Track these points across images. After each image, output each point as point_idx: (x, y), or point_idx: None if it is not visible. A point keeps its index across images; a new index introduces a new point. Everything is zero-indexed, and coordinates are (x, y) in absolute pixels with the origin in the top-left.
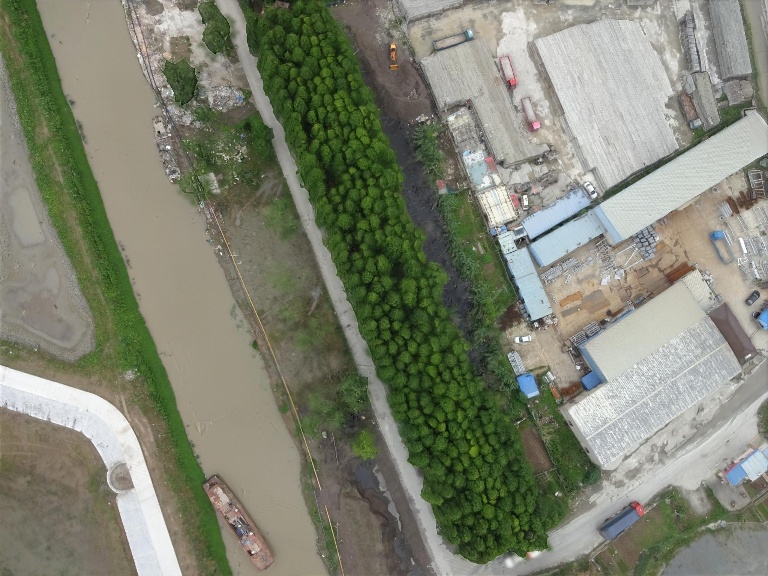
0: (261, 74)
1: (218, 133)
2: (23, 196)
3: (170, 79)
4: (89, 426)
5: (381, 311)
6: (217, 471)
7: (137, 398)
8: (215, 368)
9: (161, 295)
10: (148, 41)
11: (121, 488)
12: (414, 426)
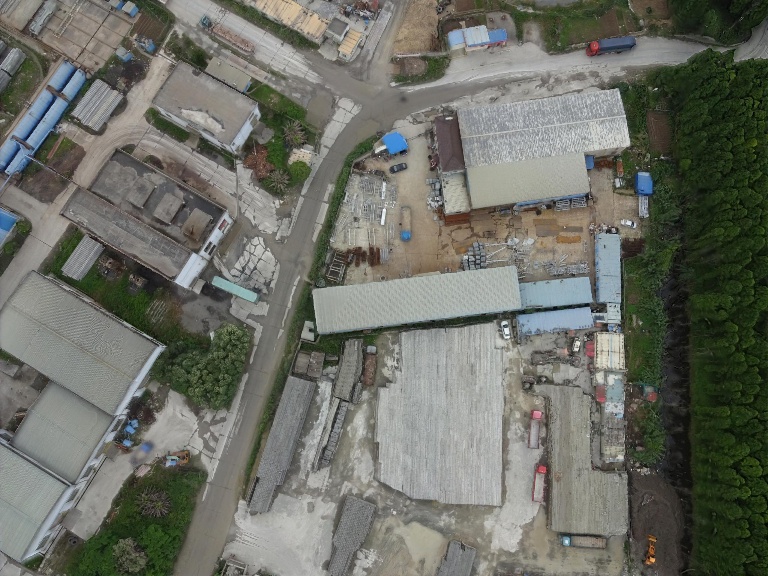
0: None
1: None
2: None
3: None
4: None
5: None
6: None
7: None
8: None
9: None
10: None
11: None
12: None
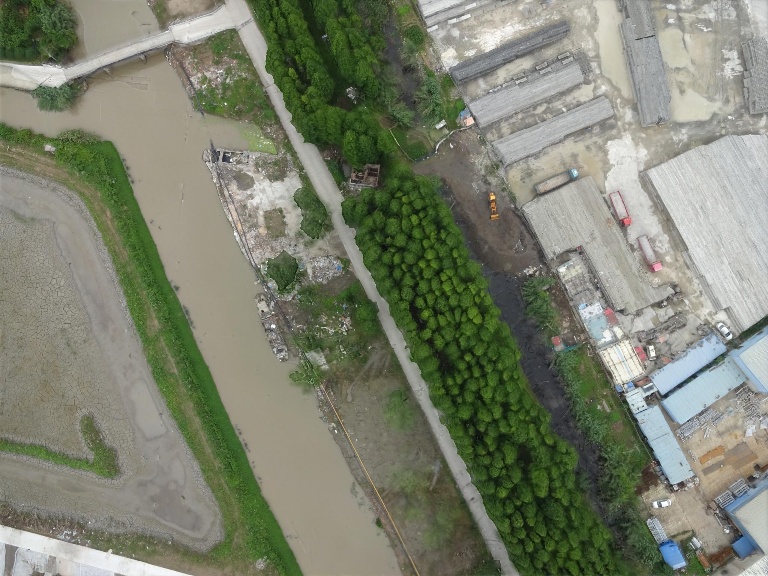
0: (360, 249)
1: (320, 306)
2: (142, 389)
3: (274, 276)
4: None
5: (513, 508)
6: None
7: None
8: (340, 546)
9: (281, 476)
10: (243, 218)
11: None
12: None
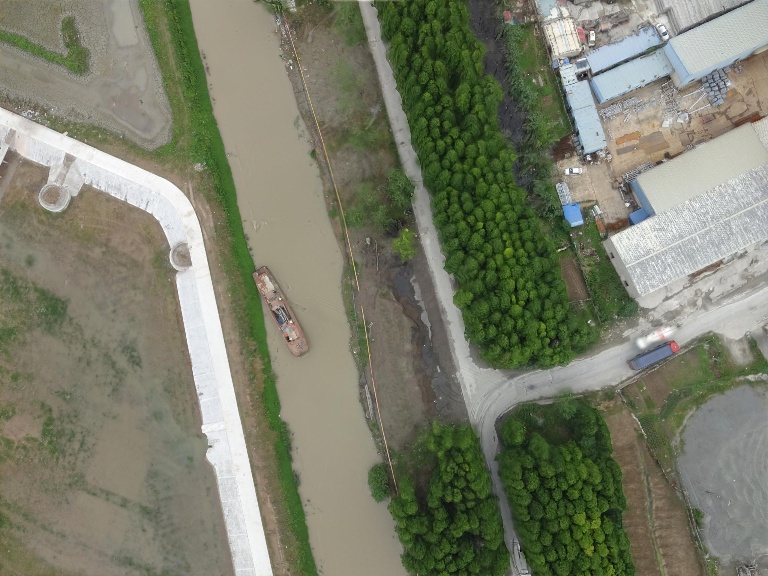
0: None
1: None
2: (124, 3)
3: None
4: (159, 209)
5: (433, 111)
6: (266, 264)
7: (203, 187)
8: (275, 174)
9: (234, 102)
10: None
11: (181, 265)
12: (452, 223)
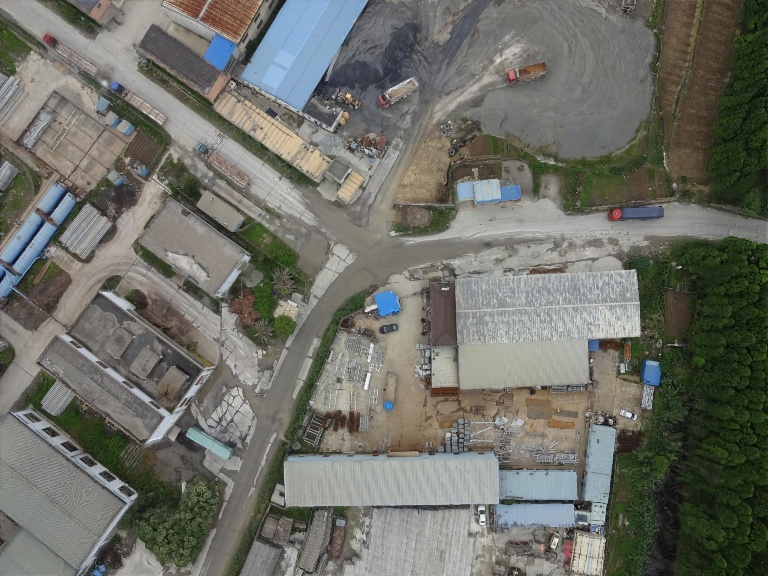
0: None
1: None
2: None
3: None
4: None
5: None
6: None
7: None
8: None
9: None
10: None
11: None
12: None
